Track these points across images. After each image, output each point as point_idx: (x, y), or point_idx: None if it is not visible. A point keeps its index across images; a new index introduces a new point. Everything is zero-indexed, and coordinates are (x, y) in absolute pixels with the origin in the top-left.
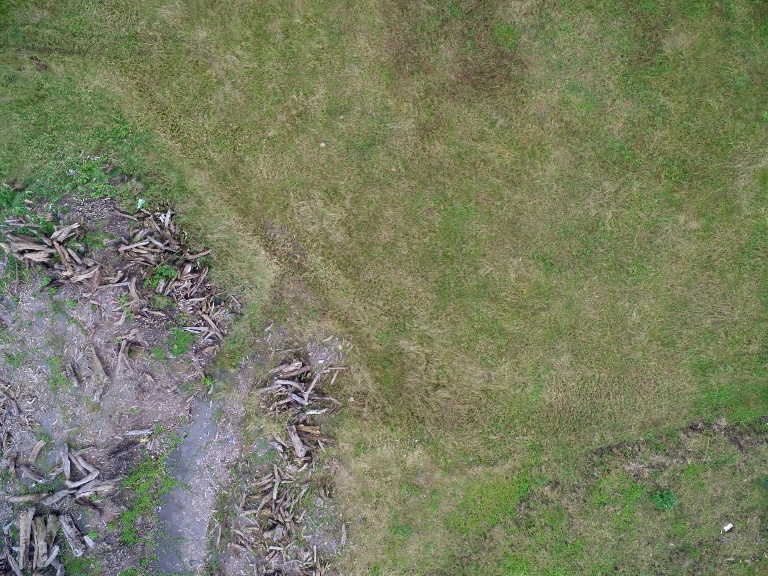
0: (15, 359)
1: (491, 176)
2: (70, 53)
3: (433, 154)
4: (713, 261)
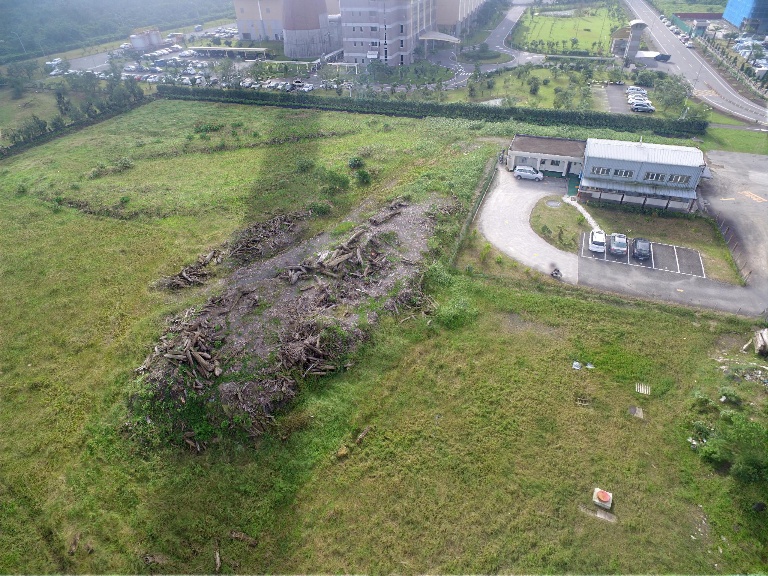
0: (275, 322)
1: (2, 307)
2: (47, 540)
3: (2, 330)
4: (3, 246)
